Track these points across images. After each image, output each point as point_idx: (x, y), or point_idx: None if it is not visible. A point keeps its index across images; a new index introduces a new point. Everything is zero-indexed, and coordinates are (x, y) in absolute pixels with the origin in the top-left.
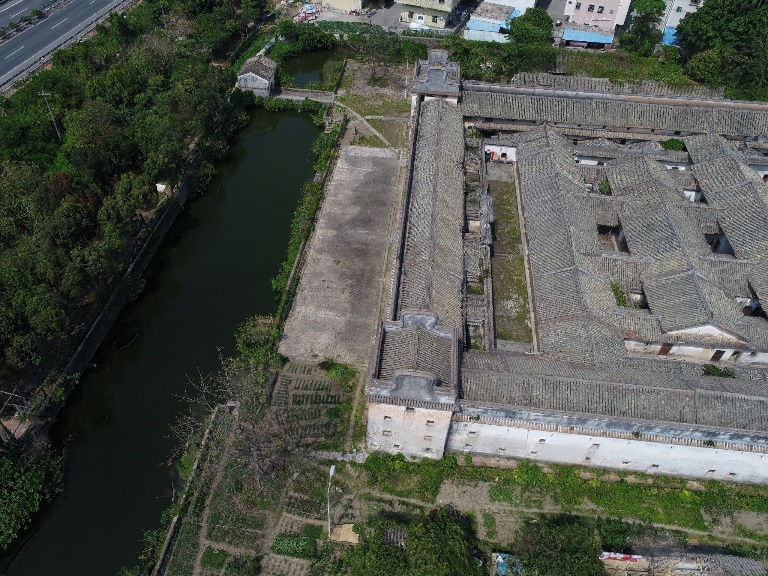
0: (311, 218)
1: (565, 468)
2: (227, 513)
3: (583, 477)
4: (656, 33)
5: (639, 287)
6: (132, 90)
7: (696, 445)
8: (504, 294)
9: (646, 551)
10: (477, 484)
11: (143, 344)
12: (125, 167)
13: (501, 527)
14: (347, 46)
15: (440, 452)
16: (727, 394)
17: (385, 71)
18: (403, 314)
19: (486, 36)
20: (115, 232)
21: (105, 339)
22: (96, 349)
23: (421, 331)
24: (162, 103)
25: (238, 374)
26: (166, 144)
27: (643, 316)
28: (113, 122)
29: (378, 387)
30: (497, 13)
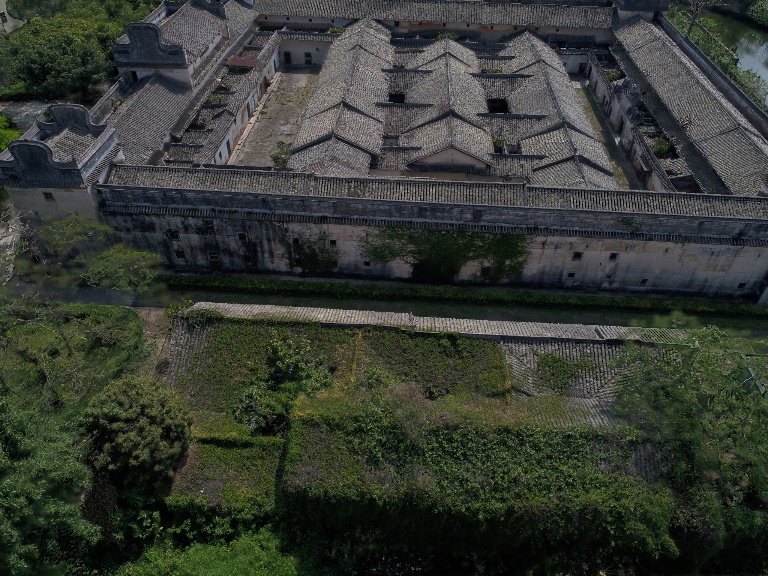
0: None
1: None
2: None
3: None
4: None
5: None
6: None
7: None
8: None
9: None
10: None
11: None
12: None
13: None
14: None
15: None
16: (466, 0)
17: None
18: None
19: None
20: None
21: None
22: None
23: None
24: None
25: None
26: None
27: (487, 57)
28: None
29: None
30: None
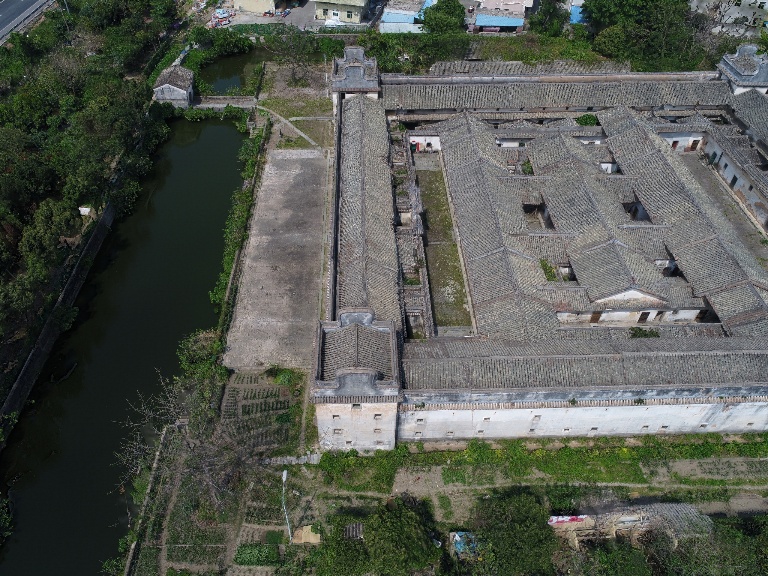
0: (243, 226)
1: (512, 442)
2: (186, 532)
3: (530, 448)
4: (563, 13)
5: (566, 261)
6: (43, 113)
7: (628, 405)
8: (441, 281)
9: (593, 510)
10: (430, 469)
11: (84, 373)
12: (44, 194)
13: (456, 507)
14: (264, 48)
15: (392, 443)
16: (651, 353)
17: (305, 71)
18: (340, 314)
19: (401, 28)
20: (39, 263)
21: (41, 373)
22: (33, 384)
23: (359, 328)
24: (76, 124)
25: (184, 392)
26: (85, 166)
27: (571, 288)
28: (26, 148)
29: (322, 388)
30: (410, 4)
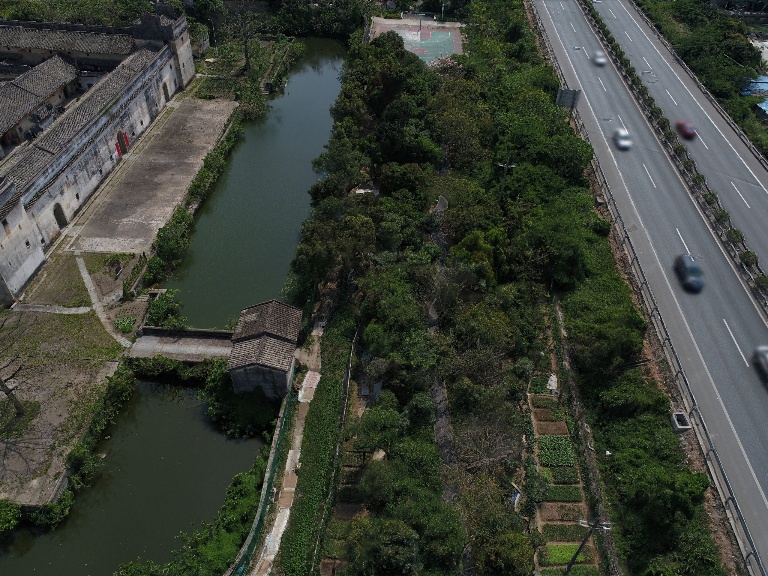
0: None
1: None
2: None
3: None
4: None
5: None
6: None
7: None
8: None
9: None
10: None
11: None
12: None
13: None
14: None
15: None
16: None
17: None
18: None
19: None
20: None
21: None
22: None
23: None
24: None
25: None
26: None
27: None
28: None
29: None
30: None
